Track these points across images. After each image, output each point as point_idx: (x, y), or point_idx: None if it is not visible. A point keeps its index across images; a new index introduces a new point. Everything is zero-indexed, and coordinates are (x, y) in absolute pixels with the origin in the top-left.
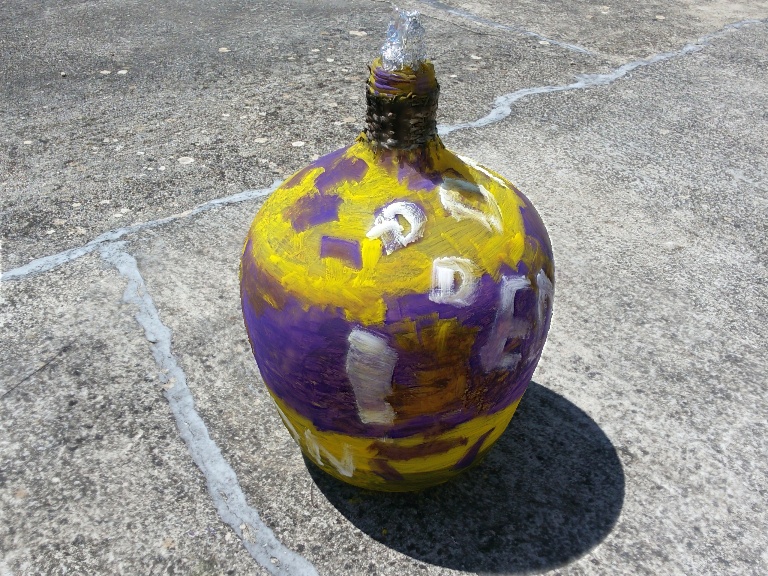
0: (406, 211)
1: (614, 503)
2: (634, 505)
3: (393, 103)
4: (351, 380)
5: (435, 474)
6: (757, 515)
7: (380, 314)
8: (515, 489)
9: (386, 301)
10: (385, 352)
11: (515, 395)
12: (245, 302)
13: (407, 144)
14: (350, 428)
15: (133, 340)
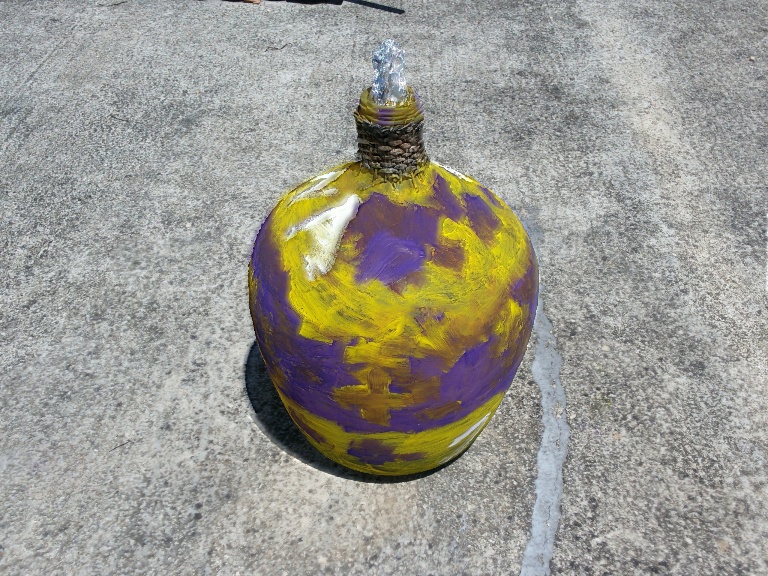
0: (439, 164)
1: None
2: None
3: None
4: None
5: None
6: None
7: None
8: None
9: None
10: None
11: None
12: None
13: None
14: None
15: None
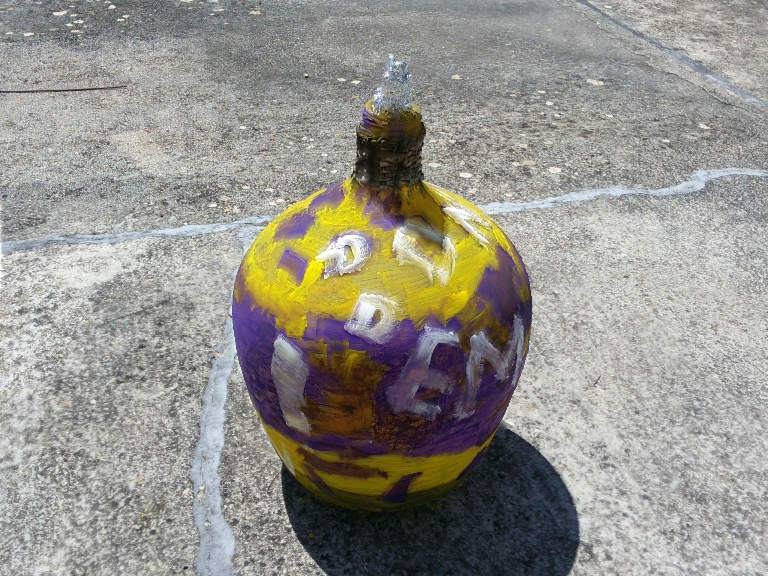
0: (356, 244)
1: None
2: None
3: (366, 144)
4: (275, 382)
5: (362, 498)
6: None
7: (300, 329)
8: (453, 543)
9: (308, 319)
10: (299, 365)
11: (444, 447)
12: None
13: (376, 184)
14: (280, 427)
15: (217, 310)
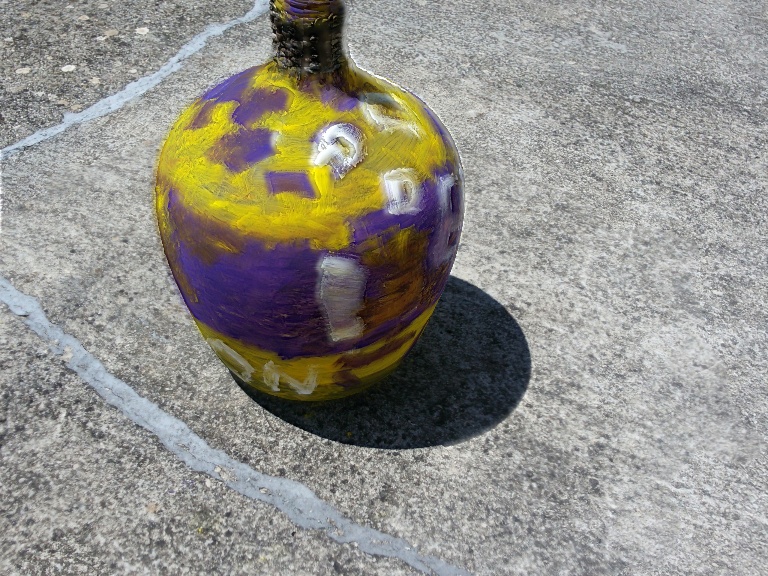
0: (345, 132)
1: (523, 353)
2: (538, 350)
3: (315, 26)
4: (325, 305)
5: (386, 370)
6: (628, 332)
7: (349, 237)
8: (441, 364)
9: (352, 223)
10: (357, 271)
11: None
12: (186, 253)
13: (330, 66)
14: (320, 349)
15: None
